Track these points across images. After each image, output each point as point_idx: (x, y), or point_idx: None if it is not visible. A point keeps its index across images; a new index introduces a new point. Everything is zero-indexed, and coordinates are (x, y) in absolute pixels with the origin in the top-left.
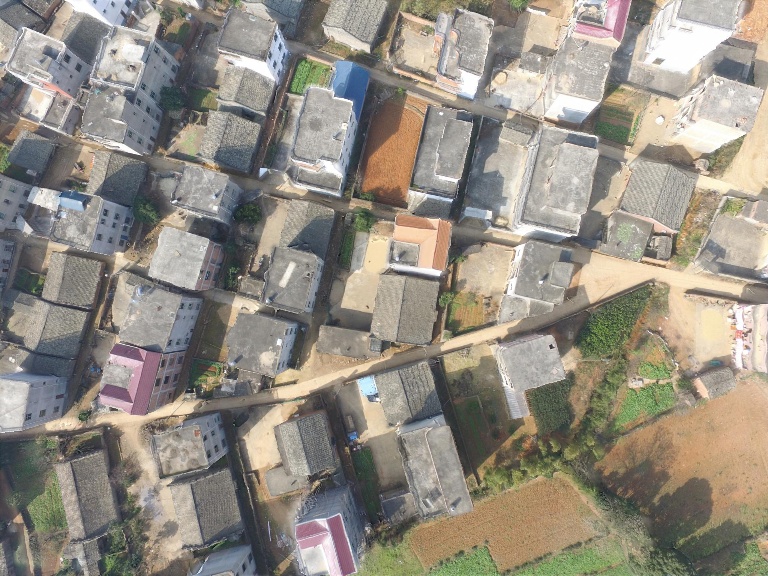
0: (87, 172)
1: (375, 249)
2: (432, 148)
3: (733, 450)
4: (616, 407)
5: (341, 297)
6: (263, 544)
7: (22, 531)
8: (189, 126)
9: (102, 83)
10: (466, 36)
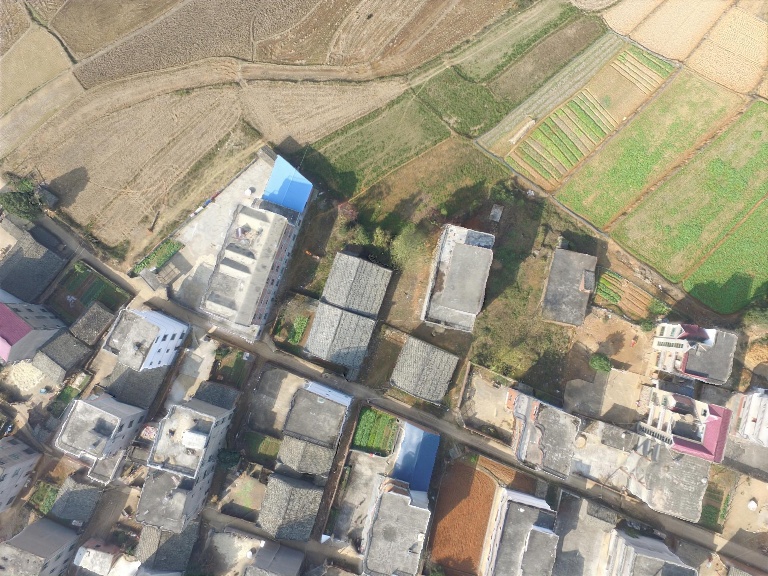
0: None
1: None
2: (512, 549)
3: None
4: None
5: None
6: None
7: None
8: (245, 474)
9: (160, 469)
10: (550, 433)
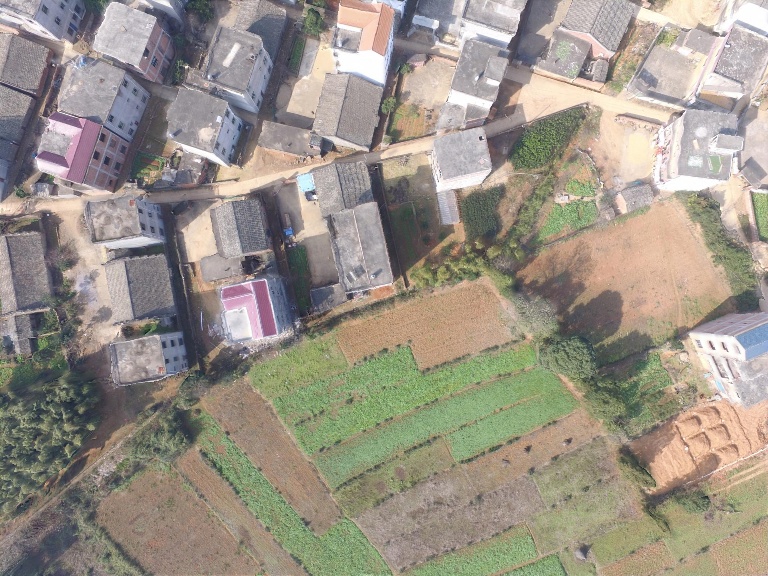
0: None
1: (324, 57)
2: None
3: (646, 266)
4: (541, 220)
5: (287, 101)
6: (194, 332)
7: None
8: None
9: None
10: None
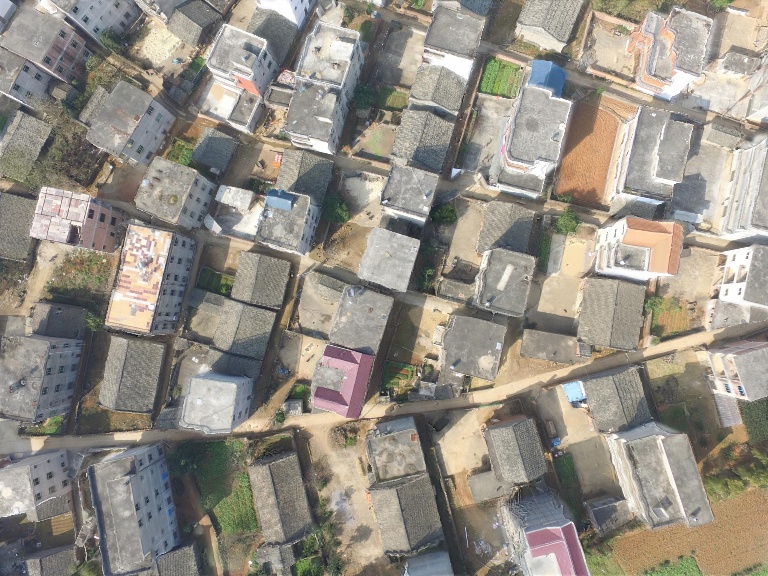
0: (269, 171)
1: (572, 252)
2: (645, 150)
3: None
4: None
5: (538, 300)
6: (461, 550)
7: (208, 533)
8: (374, 125)
9: (307, 81)
10: (683, 36)
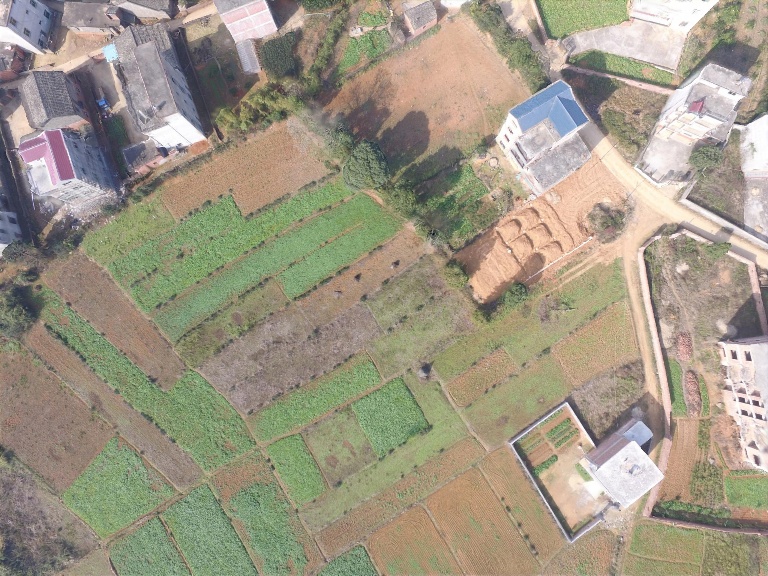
0: None
1: None
2: None
3: (445, 83)
4: (339, 55)
5: None
6: (27, 211)
7: None
8: None
9: None
10: None
